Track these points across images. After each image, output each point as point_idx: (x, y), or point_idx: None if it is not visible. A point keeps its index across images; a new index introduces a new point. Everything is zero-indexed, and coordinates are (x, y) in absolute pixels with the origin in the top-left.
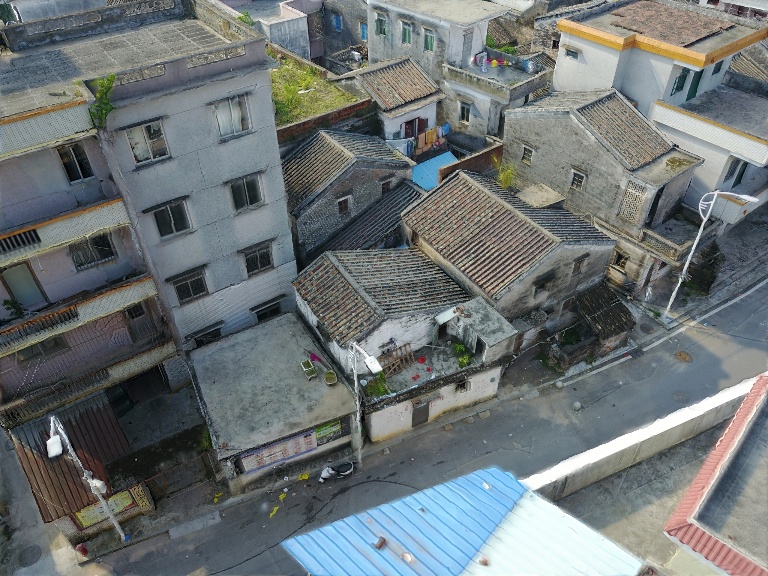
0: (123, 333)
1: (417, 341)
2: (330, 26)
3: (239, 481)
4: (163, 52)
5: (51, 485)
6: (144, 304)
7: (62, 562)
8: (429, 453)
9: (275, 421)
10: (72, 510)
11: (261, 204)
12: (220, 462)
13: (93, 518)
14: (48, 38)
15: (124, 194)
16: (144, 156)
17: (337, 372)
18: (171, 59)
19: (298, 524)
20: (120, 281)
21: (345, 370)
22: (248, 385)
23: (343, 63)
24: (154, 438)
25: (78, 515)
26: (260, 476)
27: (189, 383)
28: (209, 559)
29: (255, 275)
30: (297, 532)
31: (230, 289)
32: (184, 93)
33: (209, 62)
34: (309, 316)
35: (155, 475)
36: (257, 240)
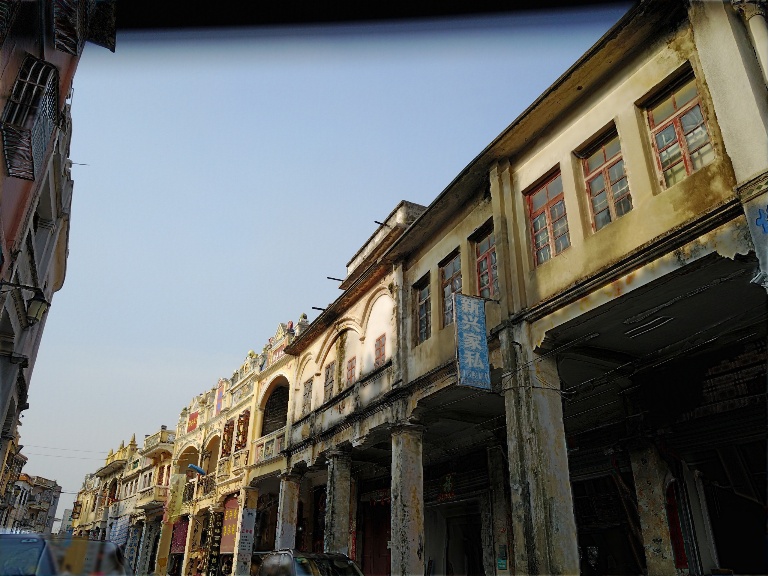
0: None
1: None
2: None
3: None
4: None
5: None
6: None
7: None
8: None
9: None
10: None
11: (48, 526)
12: None
13: None
14: None
15: None
16: None
17: None
18: None
19: None
20: None
21: None
22: None
23: None
24: None
25: None
26: None
27: None
28: None
29: None
30: None
31: None
32: None
33: None
34: None
35: None
36: None
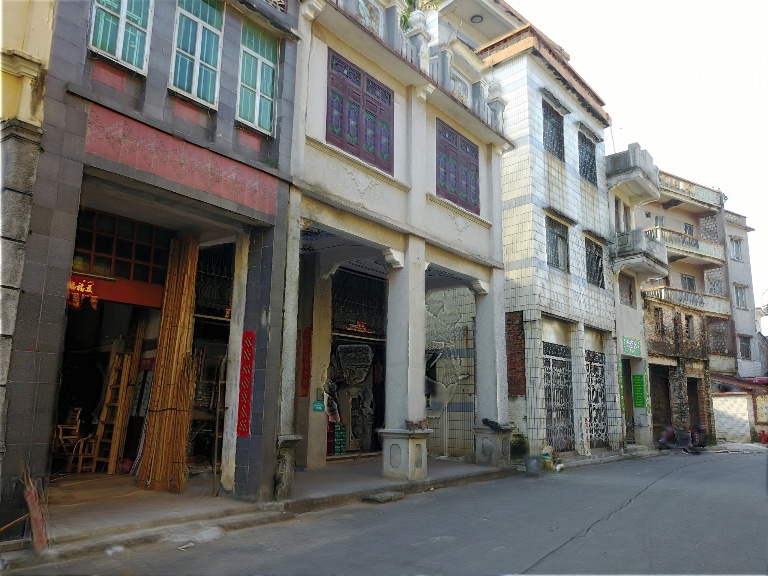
0: None
1: None
2: None
3: None
4: None
5: None
6: None
7: None
8: None
9: None
10: None
11: (745, 309)
12: None
13: (761, 417)
14: None
15: (726, 242)
16: None
17: None
18: None
19: None
20: None
21: None
22: None
23: None
24: None
25: None
26: None
27: None
28: None
29: (745, 359)
30: None
31: None
32: None
33: None
34: None
35: None
36: (744, 333)
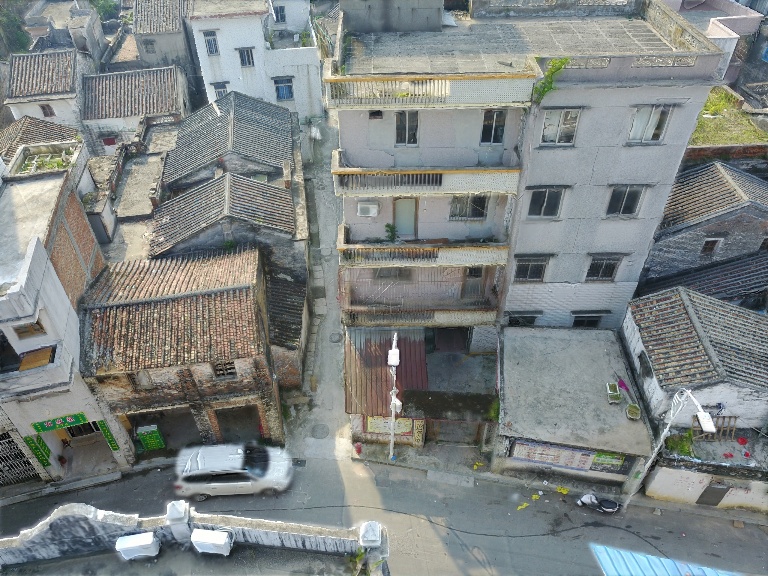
0: (457, 286)
1: (746, 419)
2: (757, 53)
3: (504, 462)
4: (606, 46)
5: (360, 385)
6: (485, 269)
7: (341, 449)
8: (706, 539)
9: (563, 426)
10: (368, 413)
11: (633, 216)
12: (494, 436)
13: (377, 428)
14: (504, 12)
15: (524, 167)
16: (550, 138)
17: (642, 409)
18: (620, 54)
19: (542, 530)
20: (477, 241)
21: (653, 411)
22: (548, 381)
23: (759, 96)
24: (441, 387)
25: (369, 419)
26: (523, 467)
27: (486, 353)
28: (452, 514)
29: (592, 281)
30: (538, 537)
31: (563, 285)
32: (615, 89)
33: (654, 65)
34: (633, 342)
35: (441, 419)
36: (611, 249)
